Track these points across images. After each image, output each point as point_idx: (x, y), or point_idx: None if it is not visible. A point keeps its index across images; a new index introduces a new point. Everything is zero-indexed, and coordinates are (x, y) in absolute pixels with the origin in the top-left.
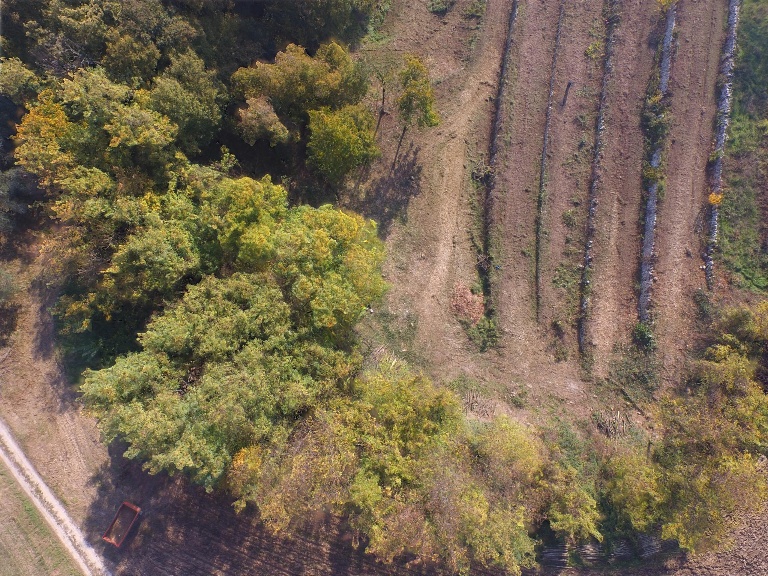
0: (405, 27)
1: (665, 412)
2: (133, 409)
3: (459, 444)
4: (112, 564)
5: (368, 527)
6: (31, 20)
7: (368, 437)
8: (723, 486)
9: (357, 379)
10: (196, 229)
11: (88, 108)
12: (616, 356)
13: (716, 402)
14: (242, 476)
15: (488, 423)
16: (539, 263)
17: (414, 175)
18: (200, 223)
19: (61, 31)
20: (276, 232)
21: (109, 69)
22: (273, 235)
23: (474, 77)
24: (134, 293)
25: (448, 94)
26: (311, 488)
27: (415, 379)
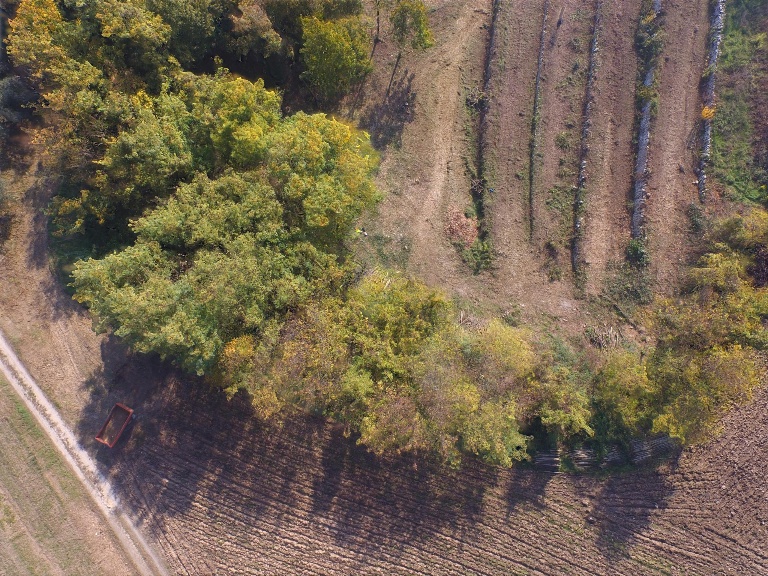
0: None
1: (657, 325)
2: (125, 292)
3: None
4: (105, 467)
5: (360, 419)
6: None
7: (360, 335)
8: (713, 373)
9: (350, 289)
10: (189, 131)
11: None
12: (609, 274)
13: (707, 302)
14: (234, 363)
15: (481, 339)
16: (533, 185)
17: (408, 102)
18: (193, 126)
19: None
20: (269, 133)
21: None
22: (266, 135)
23: (469, 5)
24: (126, 188)
25: (443, 22)
26: (302, 373)
27: (407, 283)
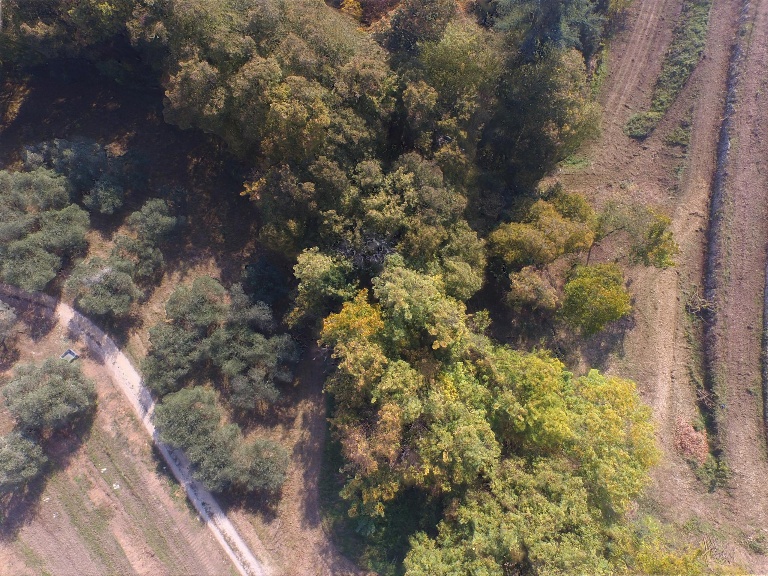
0: (602, 150)
1: None
2: None
3: None
4: None
5: None
6: (326, 207)
7: None
8: None
9: None
10: None
11: (404, 307)
12: None
13: None
14: None
15: (734, 573)
16: (767, 403)
17: None
18: (483, 400)
19: (359, 219)
20: (567, 413)
21: (406, 256)
22: None
23: (683, 207)
24: (444, 487)
25: None
26: None
27: (698, 553)
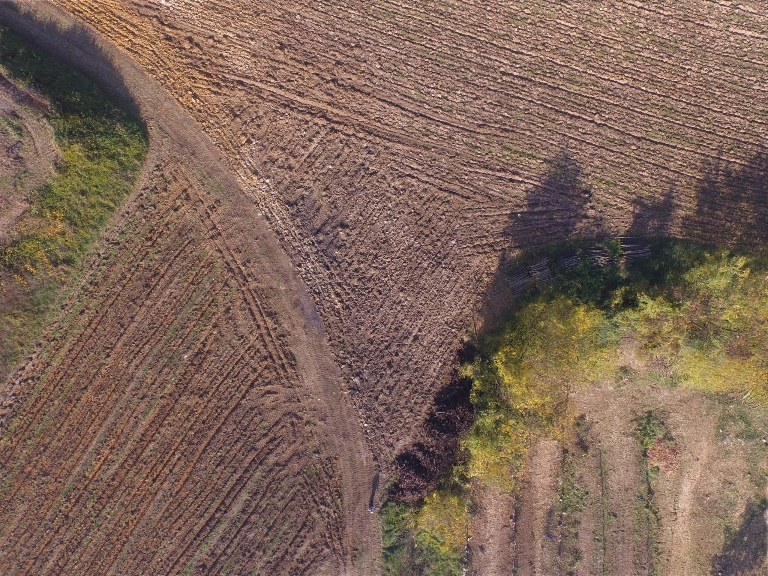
0: None
1: None
2: None
3: None
4: None
5: None
6: None
7: None
8: None
9: None
10: None
11: None
12: None
13: None
14: None
15: None
16: None
17: None
18: None
19: None
20: None
21: None
22: None
23: None
24: None
25: None
26: None
27: None
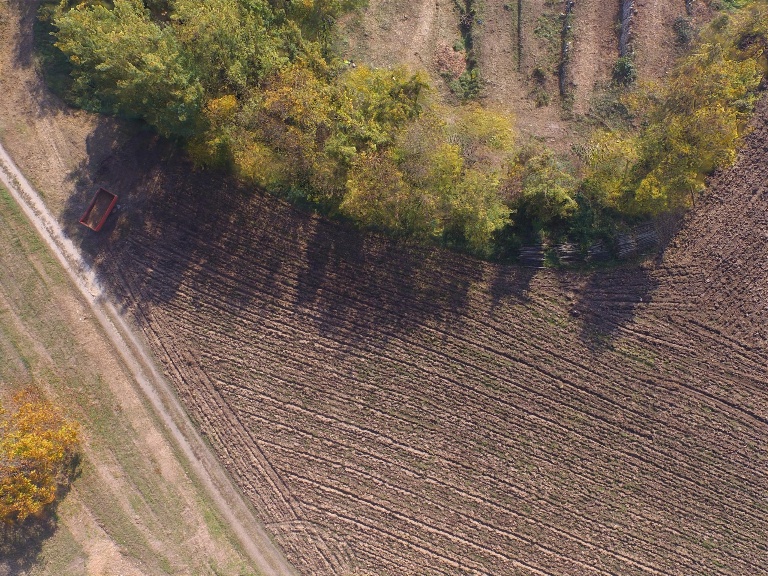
0: None
1: (644, 135)
2: None
3: None
4: (90, 256)
5: (343, 184)
6: None
7: (344, 113)
8: (695, 127)
9: None
10: None
11: None
12: (596, 94)
13: None
14: (216, 117)
15: None
16: (521, 14)
17: None
18: None
19: None
20: None
21: None
22: None
23: None
24: None
25: None
26: None
27: (393, 73)
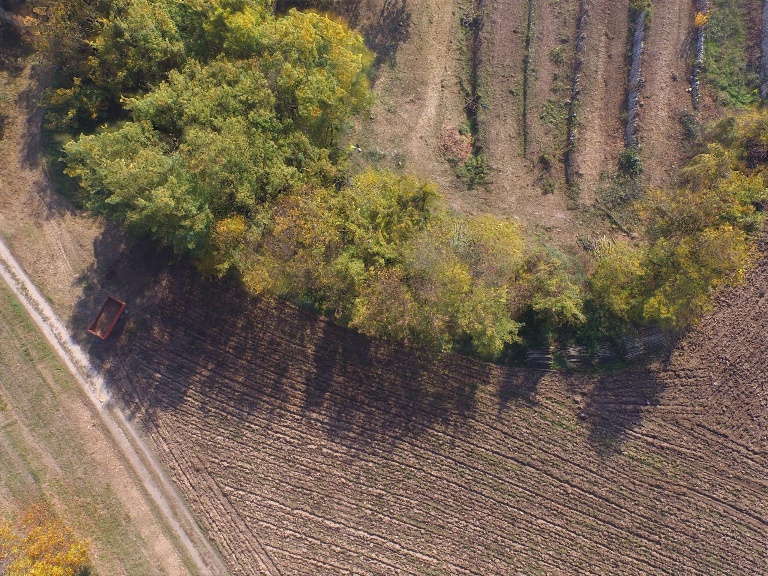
0: None
1: (650, 230)
2: (116, 165)
3: (443, 230)
4: (98, 362)
5: (351, 302)
6: None
7: (352, 224)
8: (704, 250)
9: None
10: (182, 24)
11: None
12: (602, 184)
13: None
14: (225, 240)
15: None
16: (527, 100)
17: (403, 22)
18: None
19: None
20: (261, 25)
21: None
22: (258, 26)
23: None
24: (119, 72)
25: None
26: None
27: (400, 178)
